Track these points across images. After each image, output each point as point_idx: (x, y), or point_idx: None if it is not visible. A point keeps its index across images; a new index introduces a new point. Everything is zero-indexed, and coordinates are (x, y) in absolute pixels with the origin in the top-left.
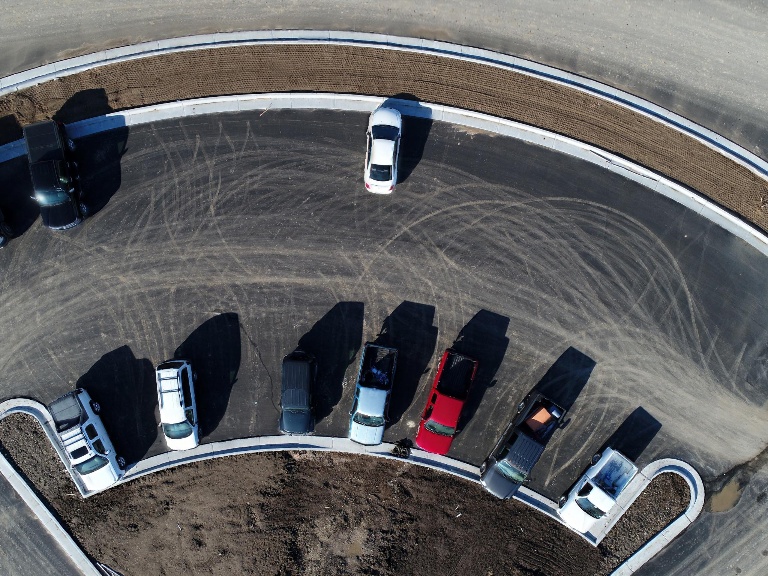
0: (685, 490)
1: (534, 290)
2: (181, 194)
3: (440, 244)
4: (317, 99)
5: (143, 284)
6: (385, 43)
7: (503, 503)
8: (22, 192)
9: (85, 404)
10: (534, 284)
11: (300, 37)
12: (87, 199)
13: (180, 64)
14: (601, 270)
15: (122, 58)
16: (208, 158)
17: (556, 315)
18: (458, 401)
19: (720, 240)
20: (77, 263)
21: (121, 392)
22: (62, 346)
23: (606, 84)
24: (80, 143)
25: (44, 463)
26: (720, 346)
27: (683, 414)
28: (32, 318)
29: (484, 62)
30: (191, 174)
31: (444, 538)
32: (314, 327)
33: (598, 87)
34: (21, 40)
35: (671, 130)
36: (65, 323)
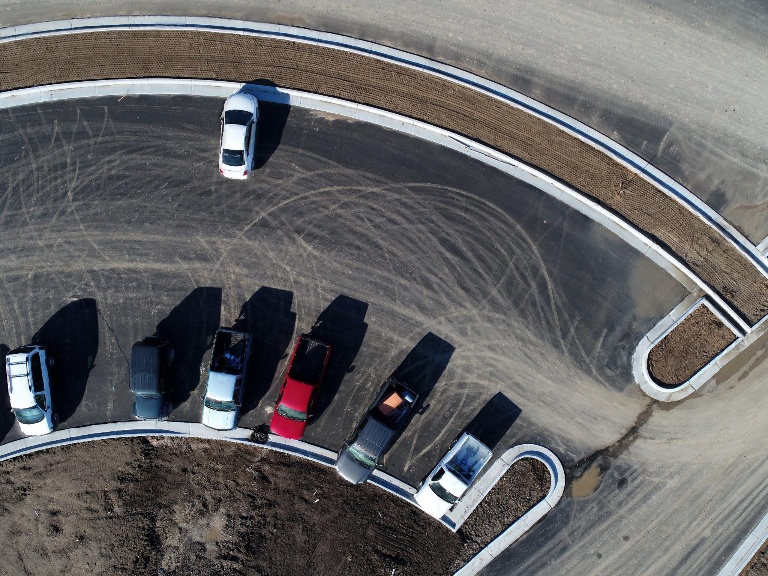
0: (545, 475)
1: (393, 275)
2: (39, 180)
3: (298, 230)
4: (175, 85)
5: (1, 270)
6: (242, 29)
7: (361, 488)
8: None
9: None
10: (393, 269)
11: (157, 23)
12: None
13: (37, 50)
14: (460, 255)
15: None
16: (66, 144)
17: (415, 300)
18: (308, 385)
19: (579, 226)
20: None
21: None
22: None
23: (464, 70)
24: None
25: None
26: (580, 331)
27: (543, 399)
28: None
29: (341, 48)
30: (49, 160)
31: (302, 524)
32: (172, 313)
33: (456, 73)
34: None
35: (529, 116)
36: None
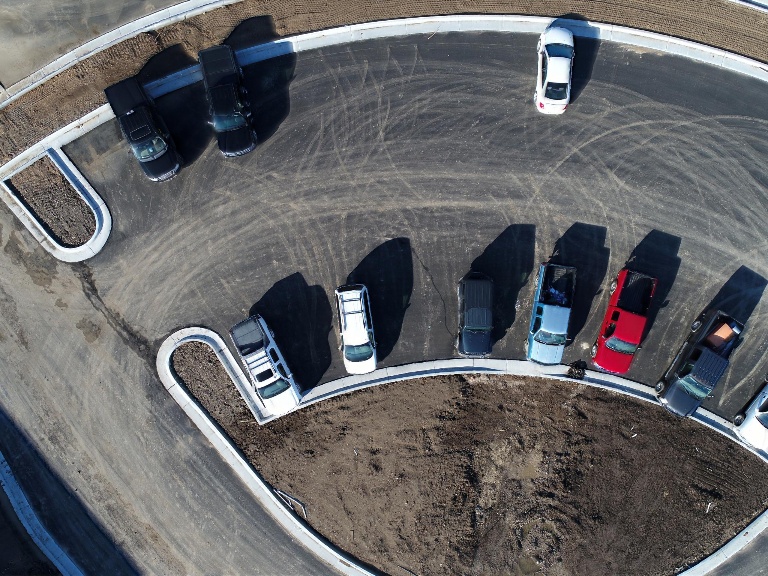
0: None
1: (705, 209)
2: (350, 120)
3: (610, 165)
4: (485, 21)
5: (314, 211)
6: None
7: (678, 423)
8: (191, 121)
9: (265, 329)
10: (705, 203)
11: None
12: (257, 127)
13: None
14: None
15: None
16: (377, 83)
17: (728, 234)
18: (642, 317)
19: None
20: (248, 191)
21: (294, 319)
22: (234, 274)
23: None
24: (248, 71)
25: (219, 391)
26: None
27: None
28: (204, 247)
29: None
30: (360, 99)
31: (620, 459)
32: (486, 250)
33: (767, 3)
34: None
35: None
36: (237, 251)
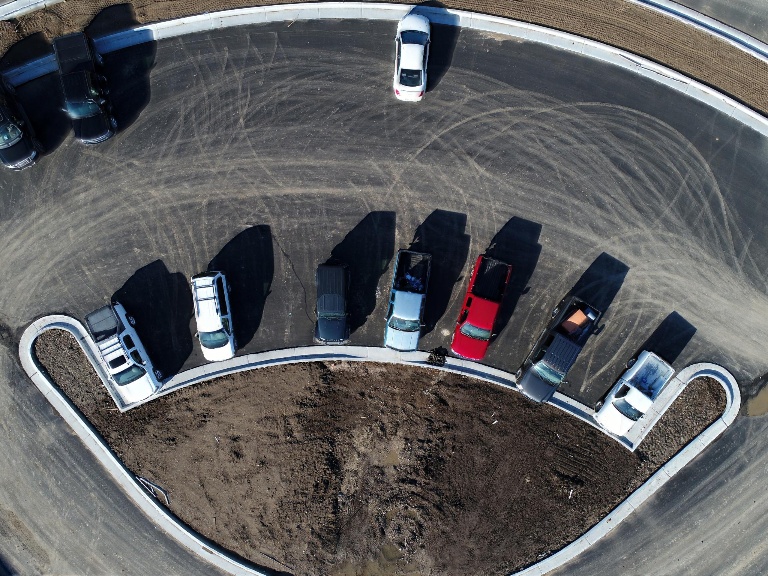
0: (721, 394)
1: (566, 196)
2: (211, 107)
3: (471, 152)
4: (344, 9)
5: (175, 198)
6: None
7: (539, 409)
8: (52, 109)
9: (121, 316)
10: (566, 190)
11: None
12: (117, 114)
13: None
14: (633, 175)
15: None
16: (237, 71)
17: (588, 221)
18: (493, 303)
19: (752, 142)
20: (109, 179)
21: (156, 306)
22: (96, 262)
23: None
24: (109, 59)
25: (81, 379)
26: (754, 249)
27: (718, 318)
28: (65, 235)
29: None
30: (220, 87)
31: (481, 445)
32: (346, 237)
33: None
34: None
35: (701, 32)
36: (98, 239)
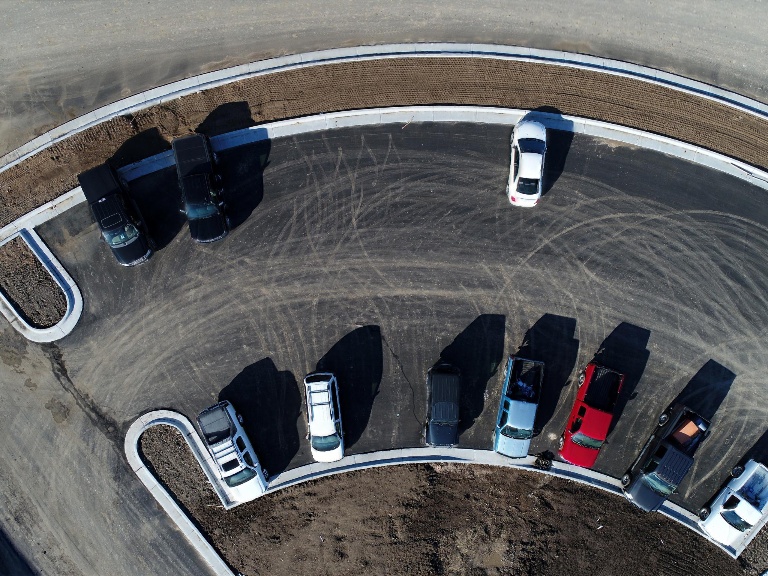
0: None
1: (675, 303)
2: (323, 207)
3: (581, 257)
4: (459, 112)
5: (285, 296)
6: (528, 56)
7: (644, 515)
8: (165, 205)
9: (233, 416)
10: (675, 297)
11: (443, 50)
12: (230, 212)
13: (323, 77)
14: (741, 283)
15: (266, 71)
16: (350, 171)
17: (696, 328)
18: (608, 414)
19: None
20: (219, 275)
21: (263, 404)
22: (204, 358)
23: (747, 97)
24: (223, 156)
25: (186, 475)
26: None
27: None
28: (175, 330)
29: (626, 75)
30: (333, 187)
31: (585, 550)
32: (456, 339)
33: (740, 100)
34: (165, 53)
35: None
36: (207, 335)
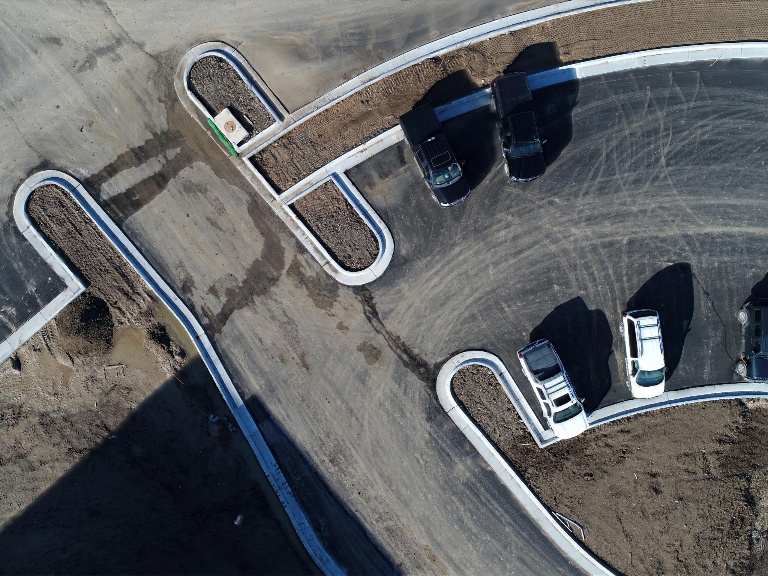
0: None
1: None
2: (632, 145)
3: None
4: (767, 48)
5: (595, 236)
6: None
7: None
8: (474, 146)
9: None
10: None
11: None
12: None
13: (632, 16)
14: None
15: (575, 11)
16: (659, 109)
17: None
18: None
19: None
20: (530, 216)
21: (574, 343)
22: (515, 298)
23: None
24: None
25: (499, 414)
26: None
27: None
28: (485, 271)
29: None
30: (642, 125)
31: None
32: (767, 275)
33: None
34: None
35: None
36: (518, 275)
